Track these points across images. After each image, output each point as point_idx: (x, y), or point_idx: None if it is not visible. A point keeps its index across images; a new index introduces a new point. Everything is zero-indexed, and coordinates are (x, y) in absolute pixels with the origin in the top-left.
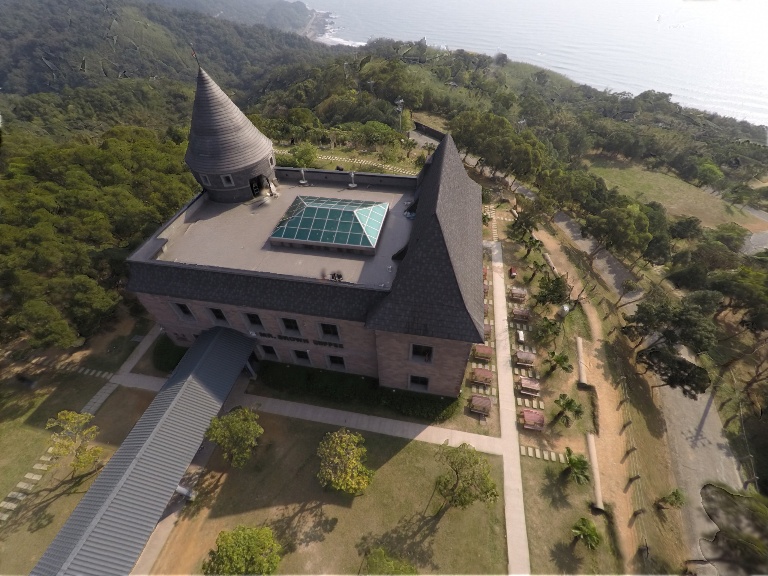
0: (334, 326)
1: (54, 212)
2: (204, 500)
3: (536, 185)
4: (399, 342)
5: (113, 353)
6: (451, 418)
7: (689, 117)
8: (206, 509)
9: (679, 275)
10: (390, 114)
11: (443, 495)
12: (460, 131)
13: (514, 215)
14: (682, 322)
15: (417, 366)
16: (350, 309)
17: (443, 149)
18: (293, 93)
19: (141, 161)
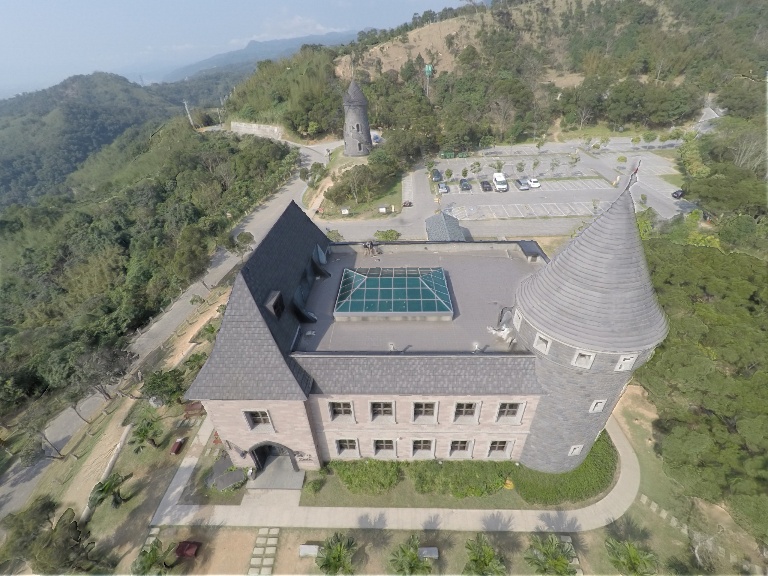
0: None
1: (764, 306)
2: None
3: None
4: None
5: None
6: None
7: None
8: None
9: None
10: None
11: None
12: None
13: None
14: None
15: None
16: None
17: (260, 253)
18: None
19: None
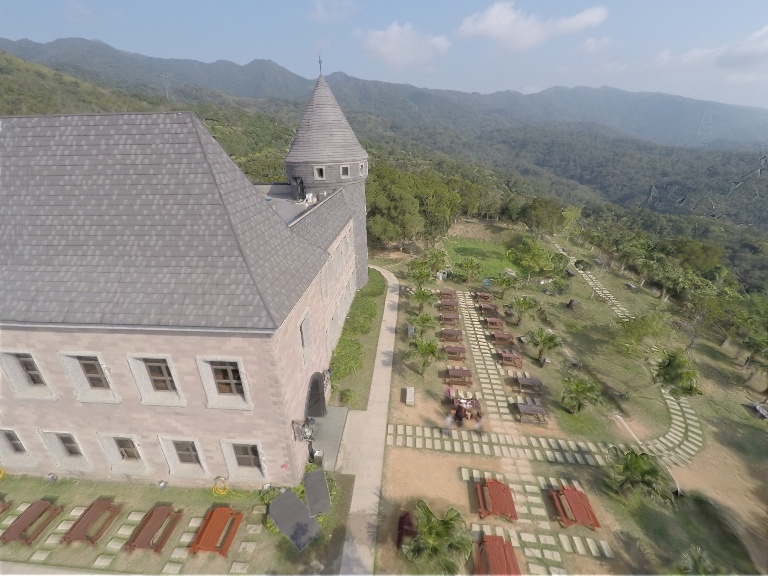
0: None
1: None
2: None
3: None
4: None
5: None
6: None
7: None
8: None
9: None
10: None
11: None
12: None
13: None
14: None
15: None
16: None
17: None
18: None
19: None
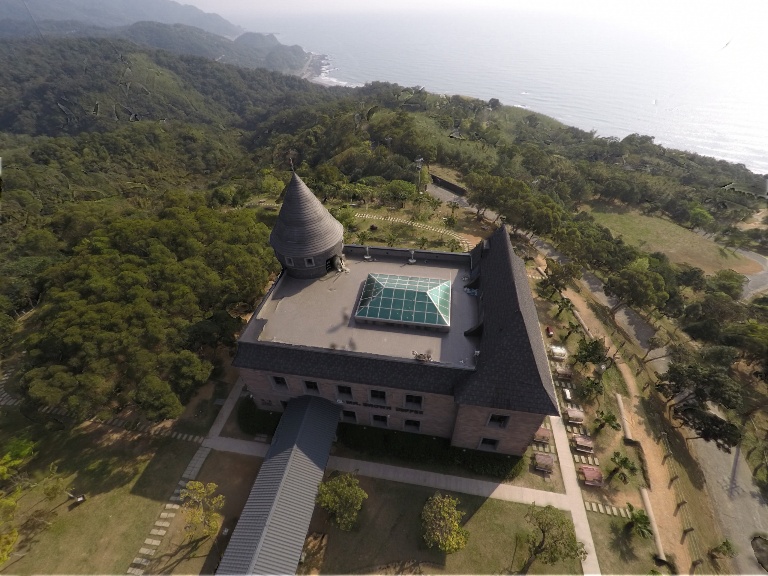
0: (420, 397)
1: (144, 286)
2: (312, 561)
3: (550, 237)
4: (480, 412)
5: (200, 417)
6: (519, 476)
7: (673, 159)
8: (316, 570)
9: (694, 329)
10: (410, 170)
11: (533, 553)
12: (482, 193)
13: (540, 273)
14: (710, 382)
15: (491, 431)
16: (437, 384)
17: (504, 242)
18: (303, 138)
19: (209, 232)
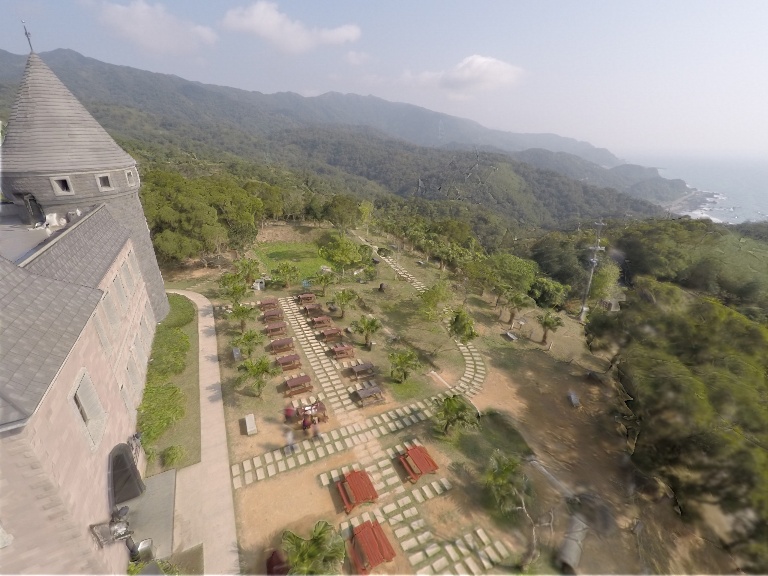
0: None
1: None
2: None
3: None
4: None
5: None
6: None
7: None
8: None
9: None
10: None
11: None
12: (616, 316)
13: None
14: None
15: None
16: None
17: None
18: None
19: None
